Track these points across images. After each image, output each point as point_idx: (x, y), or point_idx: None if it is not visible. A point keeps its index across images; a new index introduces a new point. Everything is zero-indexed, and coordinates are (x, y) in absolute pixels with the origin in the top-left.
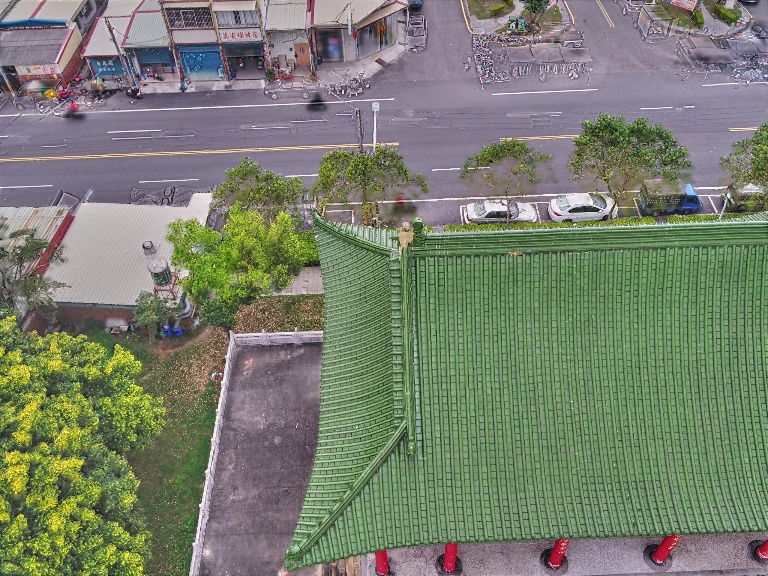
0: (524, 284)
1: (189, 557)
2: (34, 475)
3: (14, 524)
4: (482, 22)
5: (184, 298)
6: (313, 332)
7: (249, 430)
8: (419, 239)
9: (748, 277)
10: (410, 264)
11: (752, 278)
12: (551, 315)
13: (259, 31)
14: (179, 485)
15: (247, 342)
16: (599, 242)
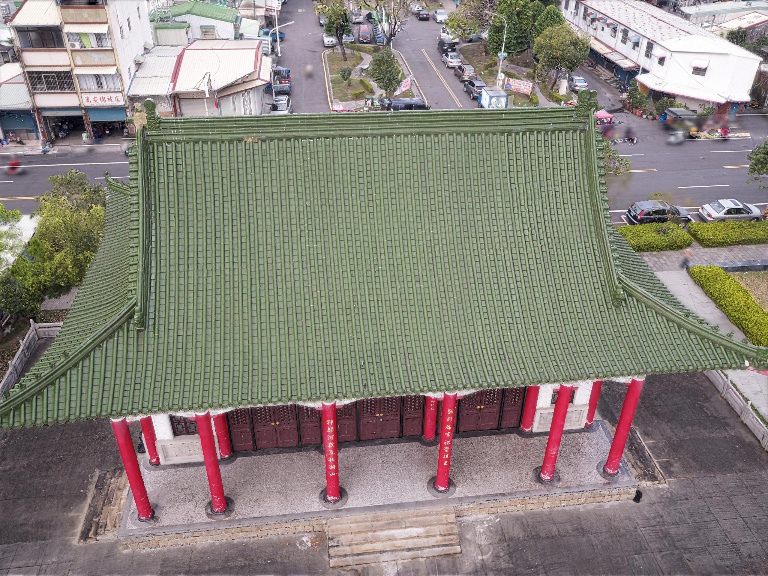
0: (262, 170)
1: None
2: None
3: None
4: (344, 103)
5: None
6: None
7: None
8: (154, 122)
9: (471, 163)
10: (148, 149)
11: (475, 165)
12: (289, 200)
13: (121, 96)
14: None
15: (51, 334)
16: (329, 128)
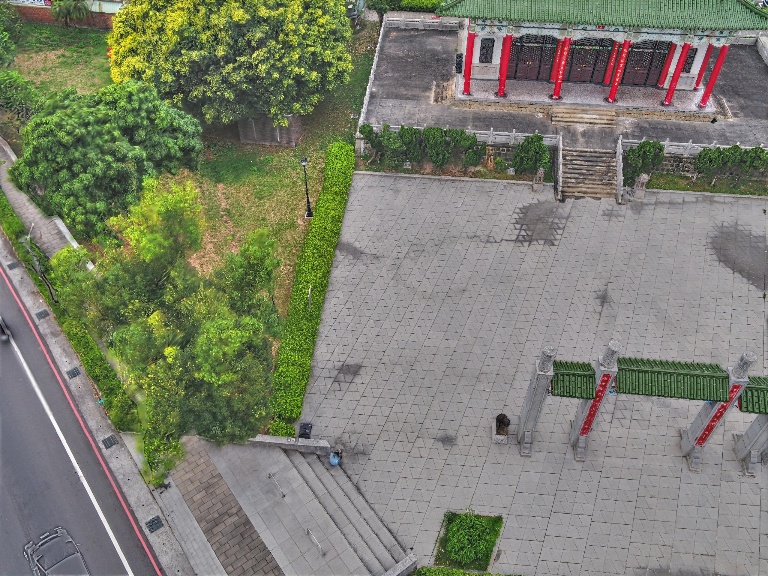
0: None
1: (360, 104)
2: (312, 2)
3: (305, 15)
4: None
5: (354, 8)
6: (432, 20)
7: (394, 56)
8: None
9: None
10: None
11: None
12: None
13: None
14: (352, 82)
15: (392, 25)
16: None
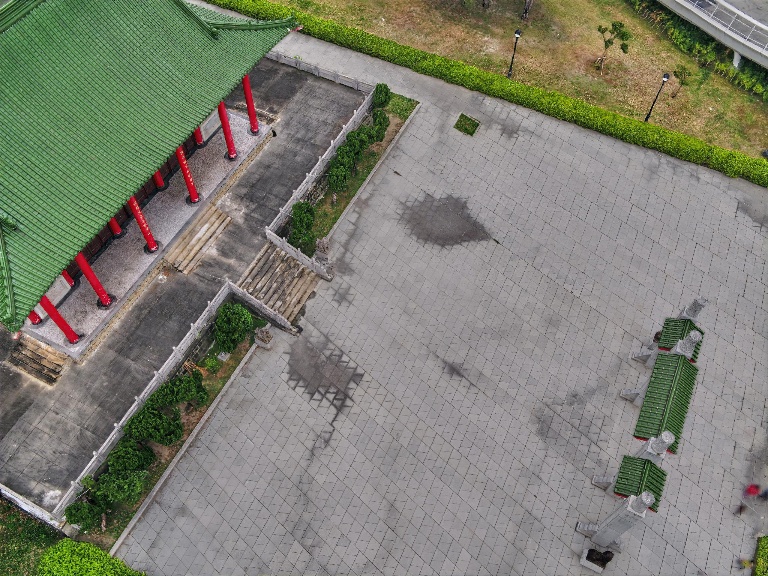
0: None
1: None
2: None
3: None
4: None
5: None
6: None
7: None
8: None
9: (85, 2)
10: None
11: (87, 1)
12: (8, 95)
13: None
14: None
15: None
16: None
